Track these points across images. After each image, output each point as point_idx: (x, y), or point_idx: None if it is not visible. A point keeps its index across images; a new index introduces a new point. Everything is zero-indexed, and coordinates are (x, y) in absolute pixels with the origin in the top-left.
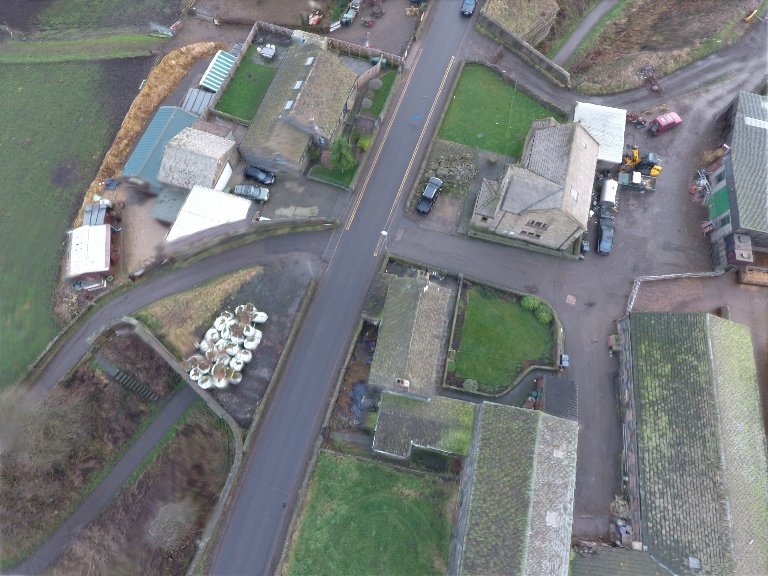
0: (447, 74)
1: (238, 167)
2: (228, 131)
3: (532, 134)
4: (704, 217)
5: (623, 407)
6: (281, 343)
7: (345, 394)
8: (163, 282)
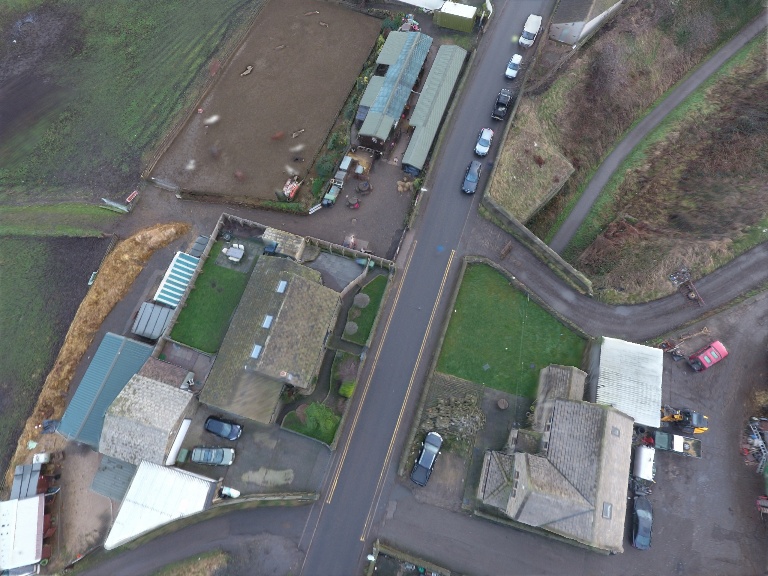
0: (446, 275)
1: (198, 413)
2: (185, 375)
3: (550, 385)
4: (760, 489)
5: None
6: None
7: None
8: (107, 569)
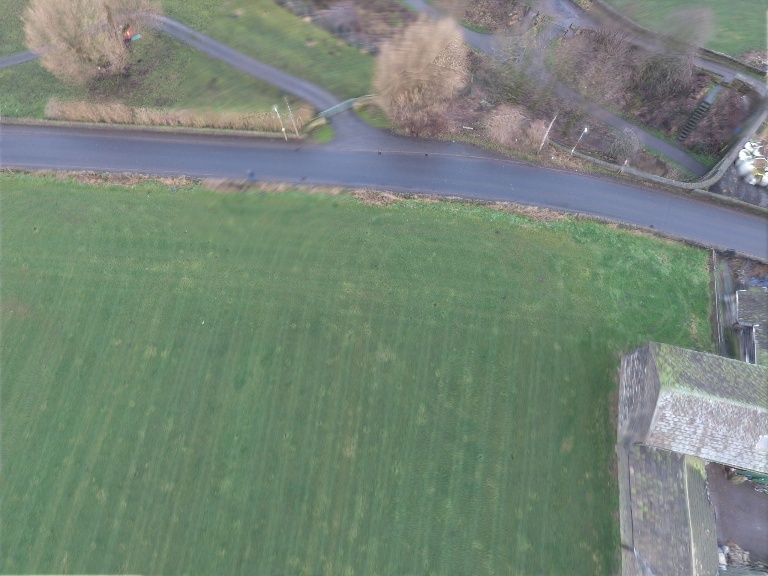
0: None
1: None
2: None
3: None
4: None
5: None
6: None
7: (767, 272)
8: None
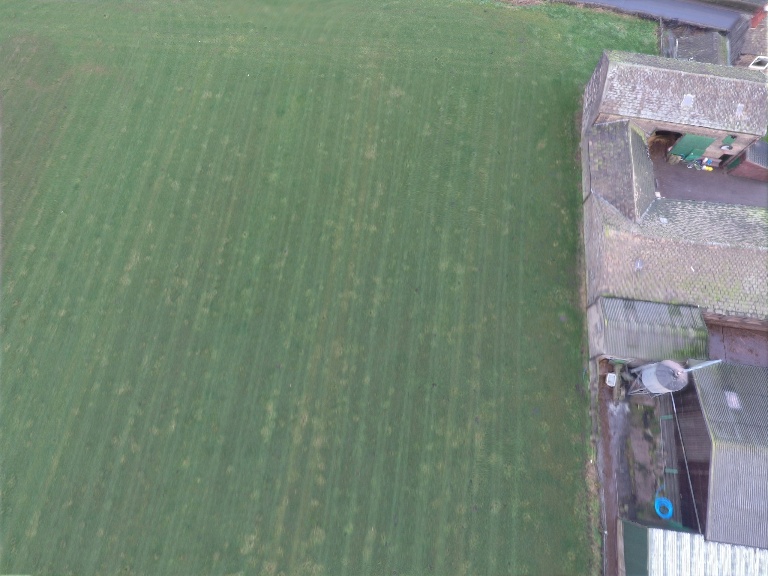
0: None
1: None
2: None
3: None
4: None
5: None
6: None
7: None
8: None
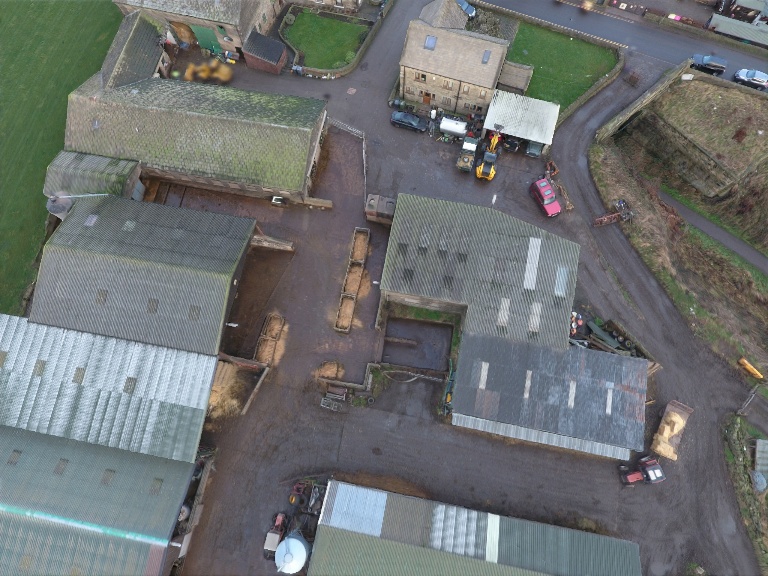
0: None
1: None
2: None
3: (516, 63)
4: None
5: None
6: None
7: None
8: None
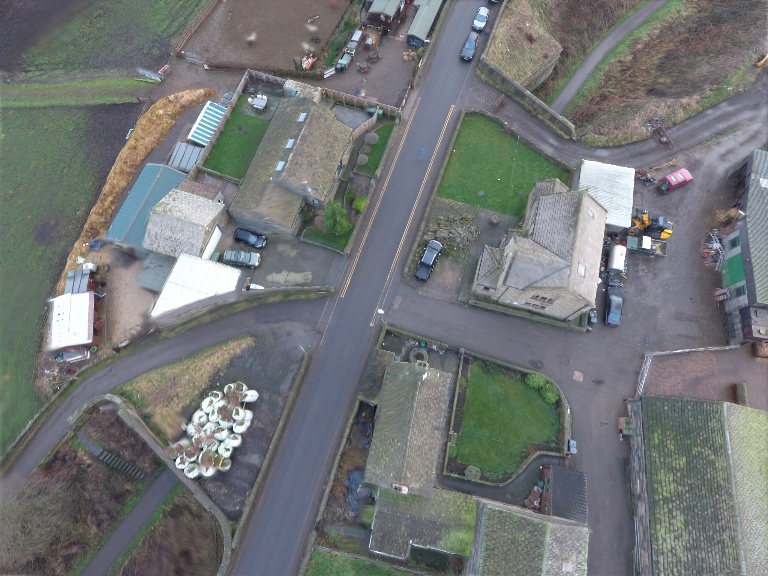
0: (446, 125)
1: (228, 228)
2: (217, 192)
3: (536, 196)
4: (717, 283)
5: (635, 498)
6: (273, 424)
7: (340, 482)
8: (149, 353)
